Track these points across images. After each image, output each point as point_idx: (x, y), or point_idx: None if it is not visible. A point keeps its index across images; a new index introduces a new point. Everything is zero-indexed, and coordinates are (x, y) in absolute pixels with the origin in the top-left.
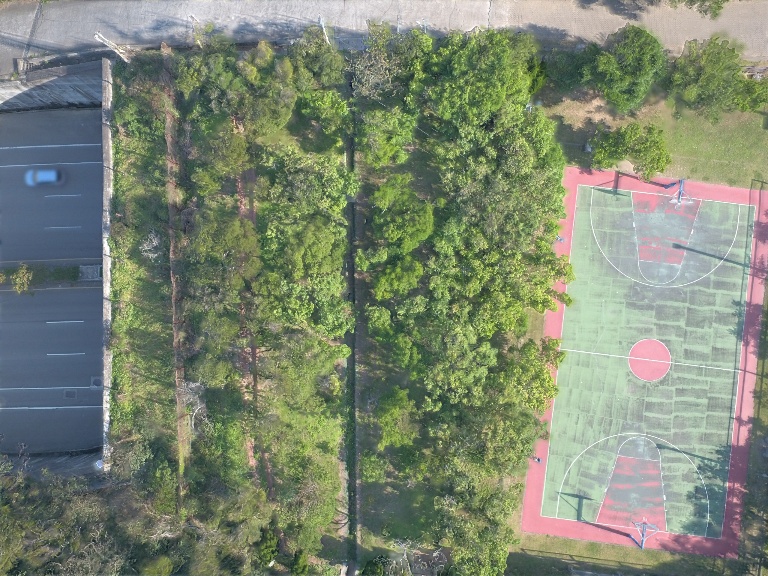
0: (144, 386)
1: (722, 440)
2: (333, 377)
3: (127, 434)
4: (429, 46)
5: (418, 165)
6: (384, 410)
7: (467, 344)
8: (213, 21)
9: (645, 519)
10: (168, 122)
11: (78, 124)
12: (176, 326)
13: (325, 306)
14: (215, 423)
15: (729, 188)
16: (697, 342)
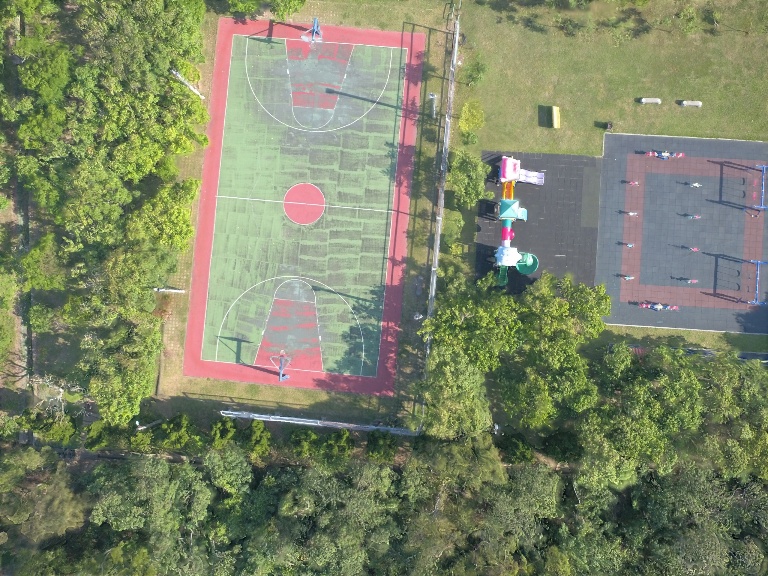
0: None
1: (376, 280)
2: None
3: None
4: None
5: None
6: None
7: (94, 181)
8: None
9: (283, 352)
10: None
11: None
12: None
13: None
14: None
15: (381, 32)
16: (351, 185)
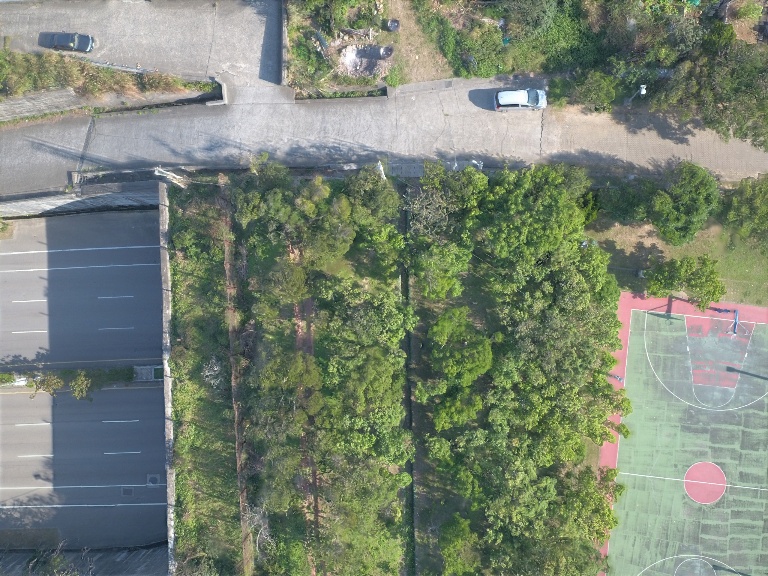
0: (207, 504)
1: None
2: (394, 505)
3: (191, 551)
4: (486, 184)
5: (473, 290)
6: (446, 540)
7: (528, 481)
8: (266, 143)
9: None
10: (227, 251)
11: (129, 227)
12: (238, 450)
13: (386, 438)
14: (277, 543)
15: None
16: (752, 464)
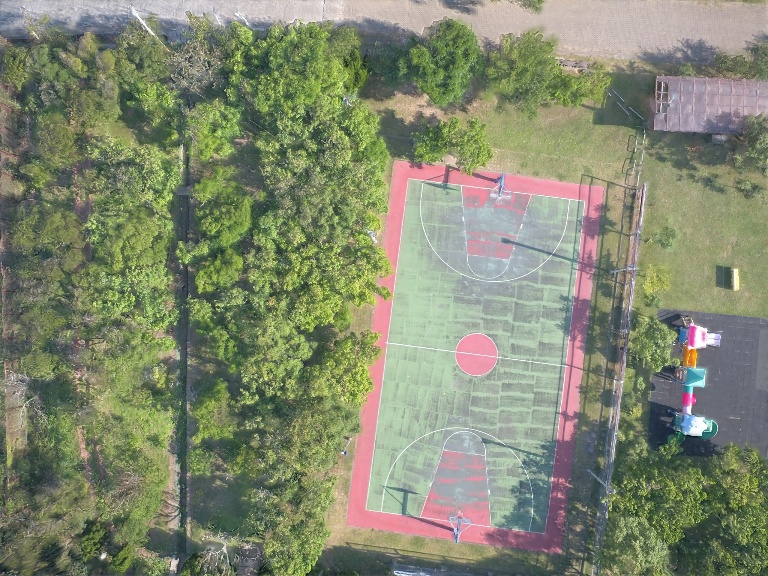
0: None
1: (547, 435)
2: (156, 369)
3: None
4: (248, 38)
5: (251, 158)
6: (202, 402)
7: (279, 337)
8: (57, 12)
9: (461, 513)
10: (2, 113)
11: None
12: (8, 317)
13: (146, 298)
14: (48, 415)
15: (559, 183)
16: (524, 337)
